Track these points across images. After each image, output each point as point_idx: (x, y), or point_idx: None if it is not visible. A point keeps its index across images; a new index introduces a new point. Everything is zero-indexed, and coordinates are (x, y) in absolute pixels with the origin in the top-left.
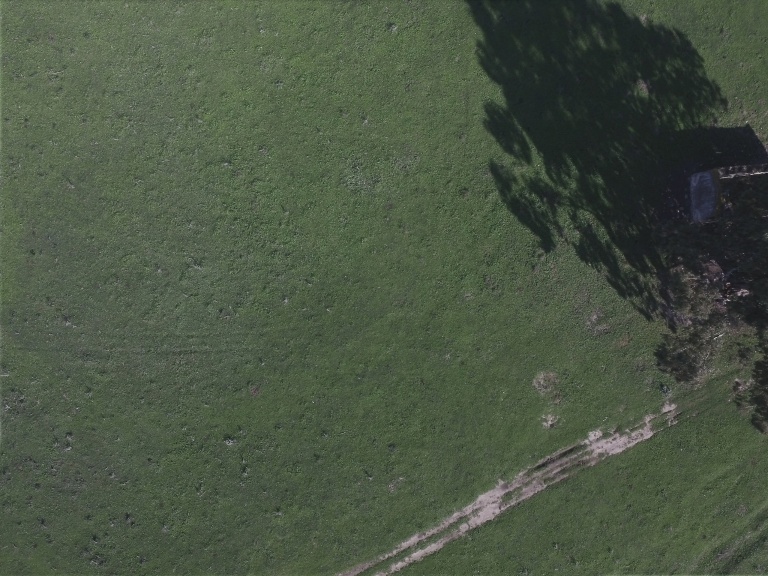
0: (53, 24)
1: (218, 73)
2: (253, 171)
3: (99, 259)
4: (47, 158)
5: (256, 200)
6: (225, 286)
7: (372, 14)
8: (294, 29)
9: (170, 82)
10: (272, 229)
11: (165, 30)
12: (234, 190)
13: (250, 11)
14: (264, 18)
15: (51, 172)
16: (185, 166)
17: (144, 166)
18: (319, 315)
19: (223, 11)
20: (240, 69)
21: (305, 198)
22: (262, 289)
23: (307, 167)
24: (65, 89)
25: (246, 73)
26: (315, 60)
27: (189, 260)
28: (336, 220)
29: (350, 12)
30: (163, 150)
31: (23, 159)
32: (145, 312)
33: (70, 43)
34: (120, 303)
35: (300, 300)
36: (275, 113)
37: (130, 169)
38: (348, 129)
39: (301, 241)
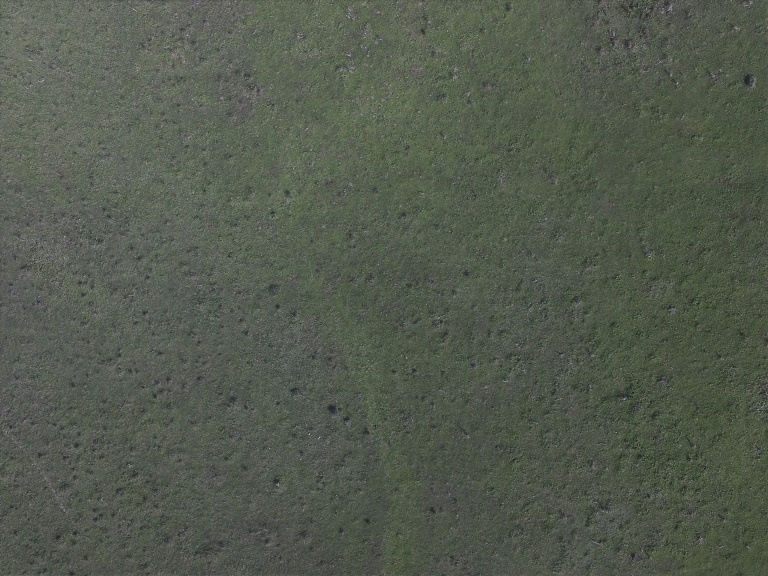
0: (432, 266)
1: (606, 302)
2: (653, 404)
3: (500, 510)
4: (438, 408)
5: (660, 435)
6: (634, 528)
7: (765, 229)
8: (681, 249)
9: (556, 316)
10: (680, 464)
11: (546, 261)
12: (635, 426)
13: (633, 234)
14: (648, 240)
15: (444, 423)
16: (580, 403)
17: (537, 407)
18: (738, 553)
19: (605, 236)
20: (628, 296)
21: (713, 429)
22: (674, 529)
23: (711, 396)
24: (450, 334)
25: (635, 300)
26: (708, 281)
27: (594, 503)
28: (748, 451)
29: (740, 228)
30: (555, 388)
31: (414, 412)
32: (553, 563)
33: (451, 284)
34: (527, 556)
35: (715, 537)
36: (669, 340)
37: (523, 411)
38: (751, 353)
39: (711, 475)
